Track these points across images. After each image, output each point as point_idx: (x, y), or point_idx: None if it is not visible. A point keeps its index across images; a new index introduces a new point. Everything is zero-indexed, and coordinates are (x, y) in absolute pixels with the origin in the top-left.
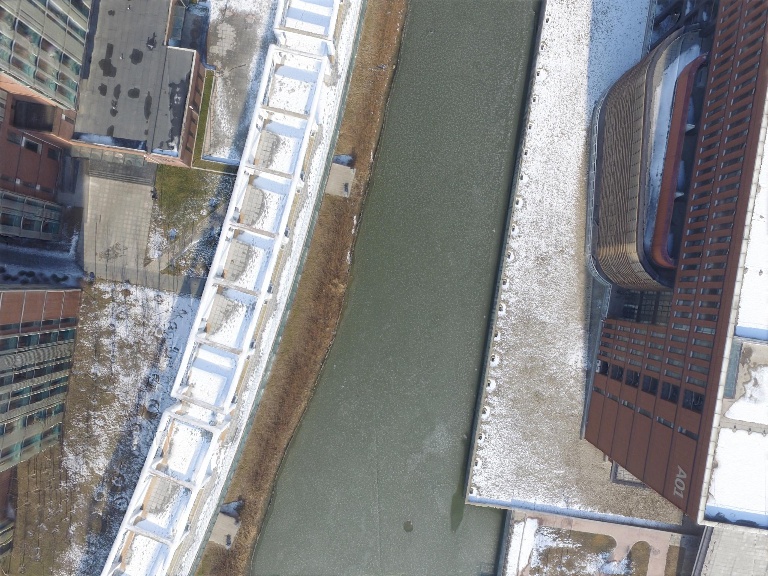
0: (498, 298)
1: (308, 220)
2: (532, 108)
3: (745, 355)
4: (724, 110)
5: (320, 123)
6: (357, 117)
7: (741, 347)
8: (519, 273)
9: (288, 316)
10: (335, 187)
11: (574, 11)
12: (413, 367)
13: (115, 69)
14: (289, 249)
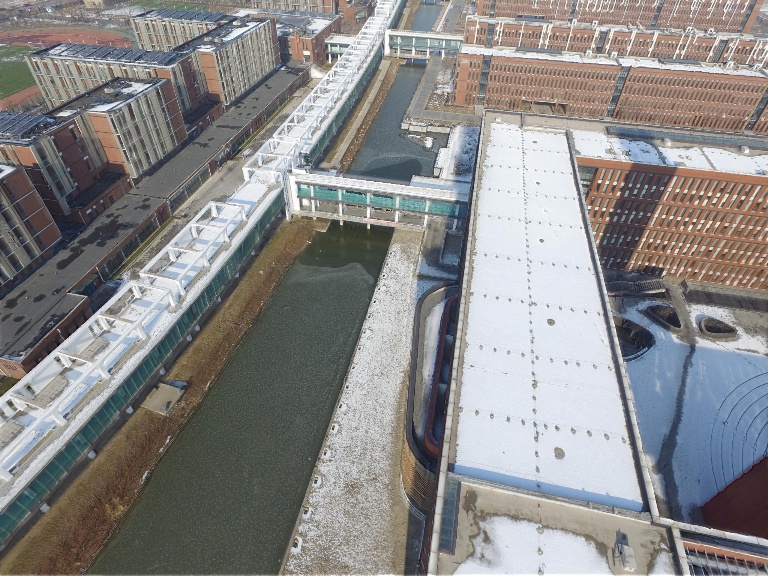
0: (294, 529)
1: (96, 406)
2: (357, 354)
3: (468, 500)
4: (457, 313)
5: (150, 335)
6: (204, 354)
7: (458, 486)
8: (324, 501)
9: (25, 521)
10: (158, 404)
11: (396, 298)
12: None
13: (17, 304)
14: (61, 432)
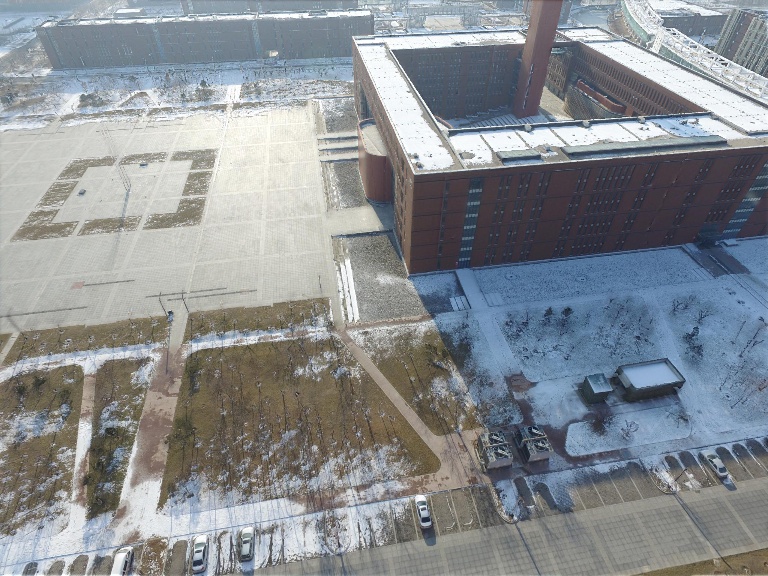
0: None
1: None
2: None
3: None
4: None
5: (760, 98)
6: None
7: None
8: None
9: None
10: None
11: None
12: None
13: None
14: None
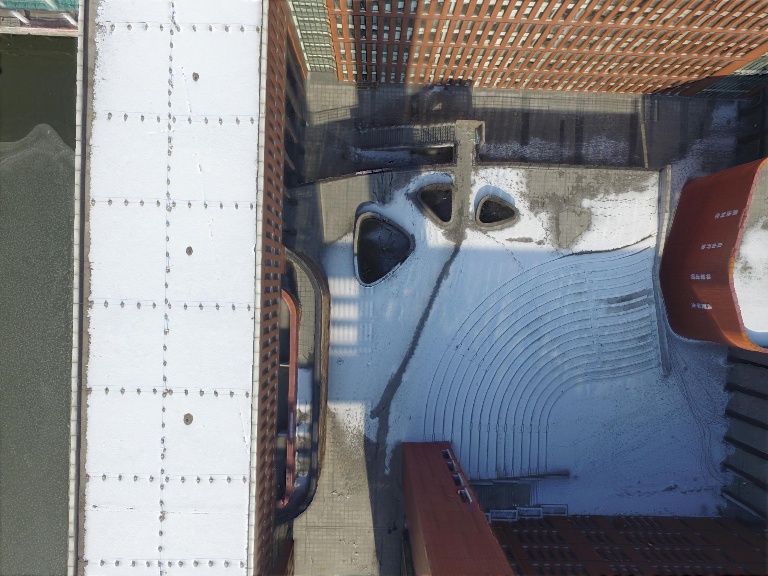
0: None
1: None
2: None
3: None
4: None
5: None
6: None
7: None
8: None
9: None
10: None
11: None
12: (4, 575)
13: None
14: None
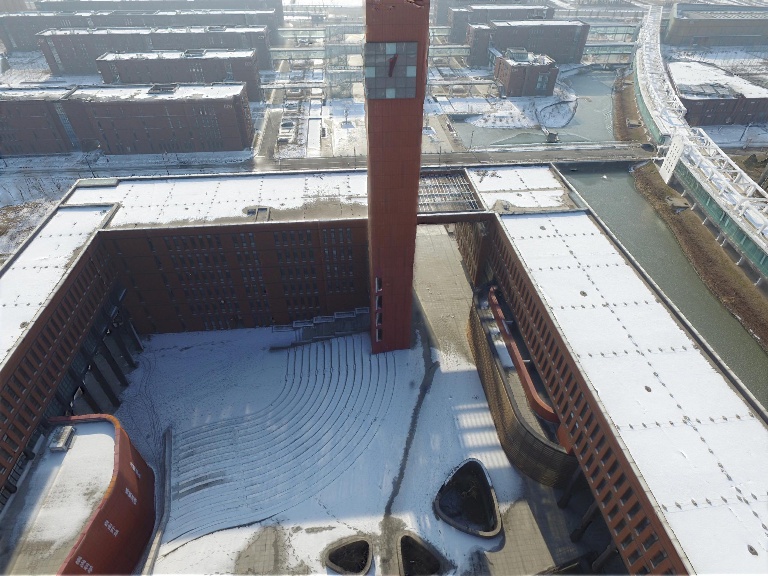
0: None
1: None
2: None
3: None
4: None
5: None
6: None
7: (580, 207)
8: None
9: None
10: None
11: None
12: None
13: None
14: None
